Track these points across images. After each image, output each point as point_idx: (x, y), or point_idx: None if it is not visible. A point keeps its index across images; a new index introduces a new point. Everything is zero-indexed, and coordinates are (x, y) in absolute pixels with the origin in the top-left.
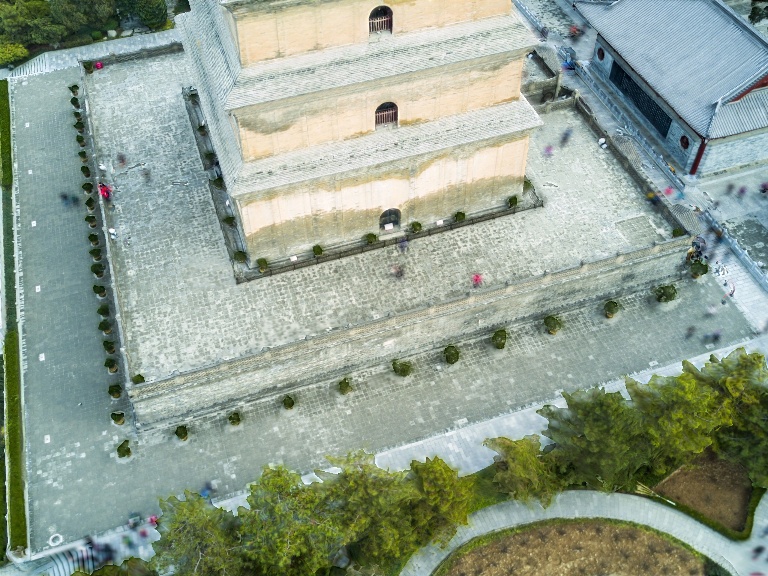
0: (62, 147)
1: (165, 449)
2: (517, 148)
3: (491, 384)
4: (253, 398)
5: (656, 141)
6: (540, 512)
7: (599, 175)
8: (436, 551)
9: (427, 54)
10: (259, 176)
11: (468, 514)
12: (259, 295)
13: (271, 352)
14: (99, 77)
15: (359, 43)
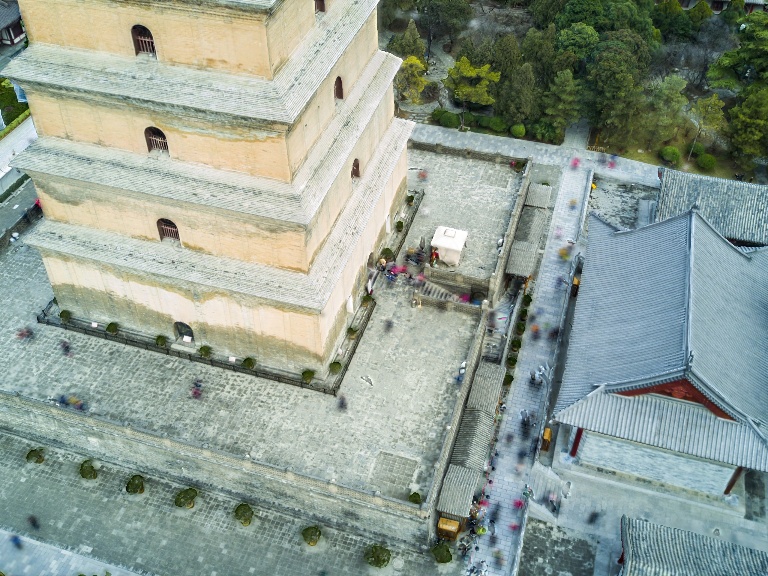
0: None
1: None
2: (306, 322)
3: (145, 533)
4: None
5: None
6: None
7: (424, 396)
8: None
9: (193, 188)
10: (51, 236)
11: None
12: (41, 340)
13: None
14: None
15: (139, 154)
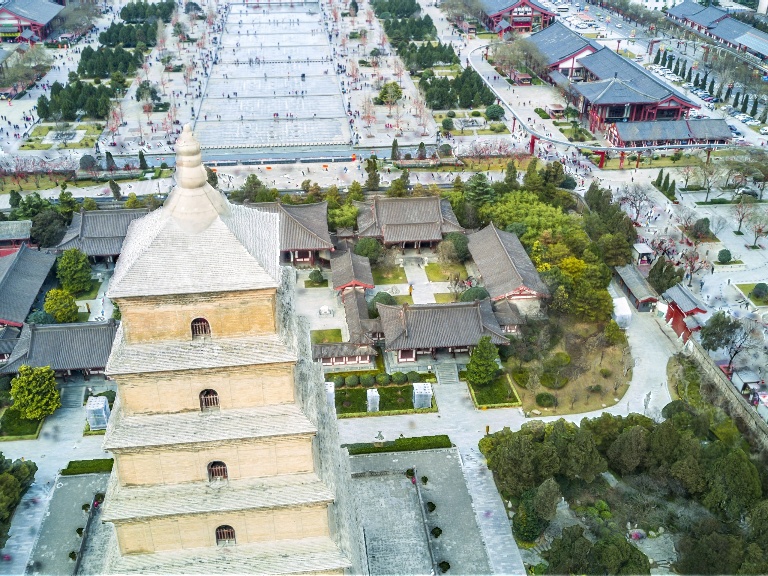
0: None
1: None
2: None
3: None
4: None
5: None
6: None
7: None
8: None
9: None
10: None
11: None
12: None
13: None
14: (402, 482)
15: None
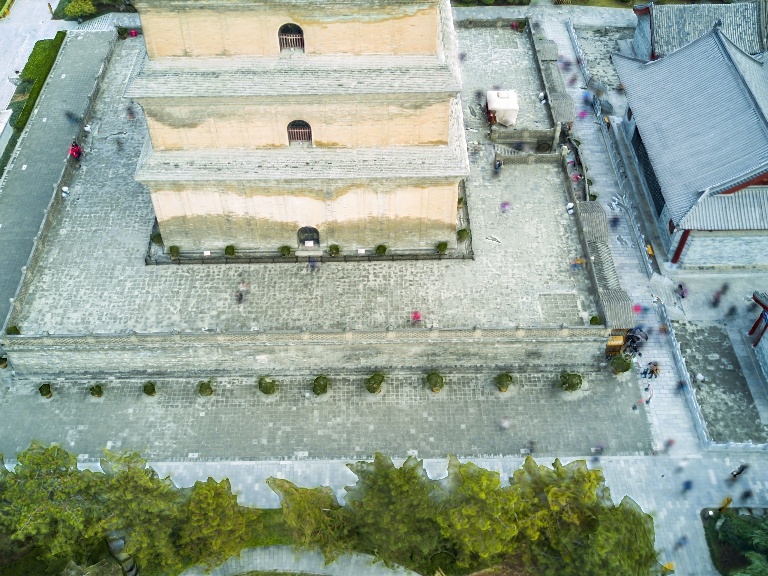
0: (81, 103)
1: (28, 401)
2: (445, 193)
3: (349, 425)
4: (124, 376)
5: (652, 218)
6: (330, 566)
7: (550, 240)
8: (213, 572)
9: (337, 80)
10: (165, 167)
11: (260, 546)
12: (160, 280)
13: (137, 337)
14: (129, 44)
15: (269, 56)
